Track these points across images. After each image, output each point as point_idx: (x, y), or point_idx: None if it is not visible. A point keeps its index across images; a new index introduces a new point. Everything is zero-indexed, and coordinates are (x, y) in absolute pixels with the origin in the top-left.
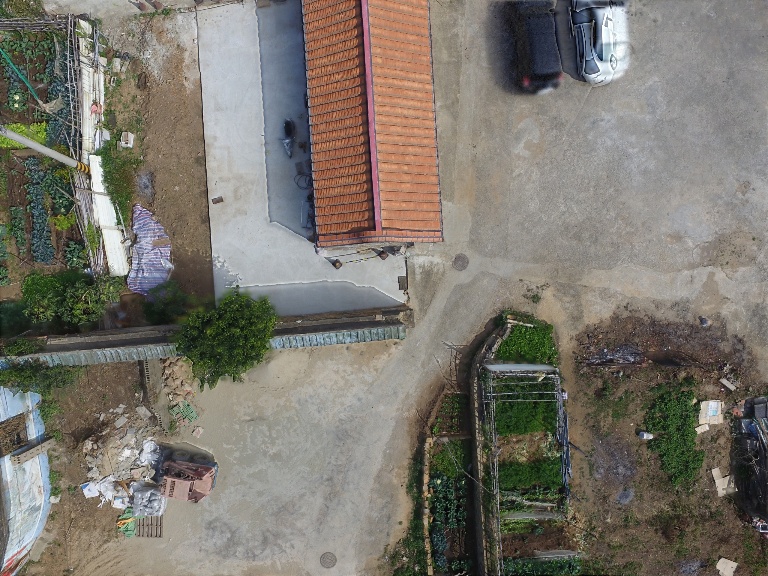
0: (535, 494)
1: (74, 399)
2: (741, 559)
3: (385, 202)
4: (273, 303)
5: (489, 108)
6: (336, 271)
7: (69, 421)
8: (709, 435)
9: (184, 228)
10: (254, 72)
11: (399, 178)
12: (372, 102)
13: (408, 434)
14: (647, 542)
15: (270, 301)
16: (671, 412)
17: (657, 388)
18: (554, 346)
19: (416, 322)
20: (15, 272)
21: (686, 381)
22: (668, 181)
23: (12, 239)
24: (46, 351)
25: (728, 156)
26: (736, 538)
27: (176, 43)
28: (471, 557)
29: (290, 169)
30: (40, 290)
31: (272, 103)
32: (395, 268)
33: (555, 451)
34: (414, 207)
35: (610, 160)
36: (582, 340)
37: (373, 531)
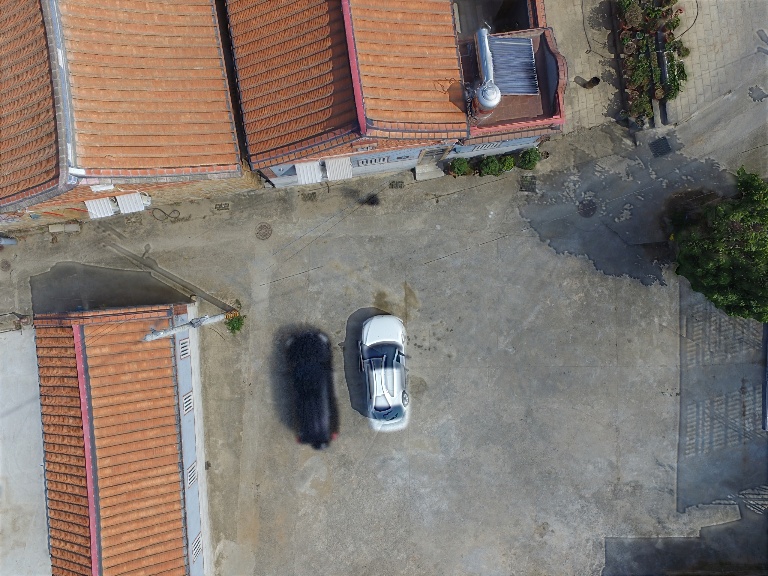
0: None
1: None
2: None
3: None
4: None
5: (273, 446)
6: None
7: None
8: None
9: None
10: (33, 401)
11: None
12: (95, 523)
13: None
14: None
15: None
16: None
17: None
18: None
19: None
20: None
21: None
22: (462, 522)
23: None
24: None
25: (526, 496)
26: None
27: None
28: None
29: None
30: None
31: None
32: None
33: None
34: None
35: (401, 499)
36: None
37: None
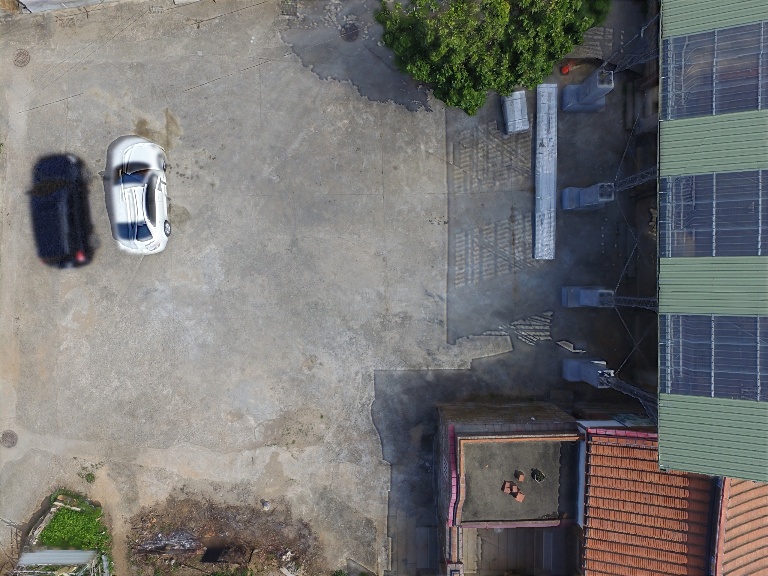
0: None
1: None
2: None
3: None
4: None
5: (33, 277)
6: None
7: None
8: None
9: None
10: None
11: None
12: None
13: None
14: None
15: None
16: None
17: None
18: (105, 530)
19: None
20: None
21: None
22: (228, 355)
23: None
24: None
25: (293, 328)
26: None
27: None
28: None
29: None
30: None
31: None
32: None
33: None
34: None
35: (166, 332)
36: (136, 524)
37: None
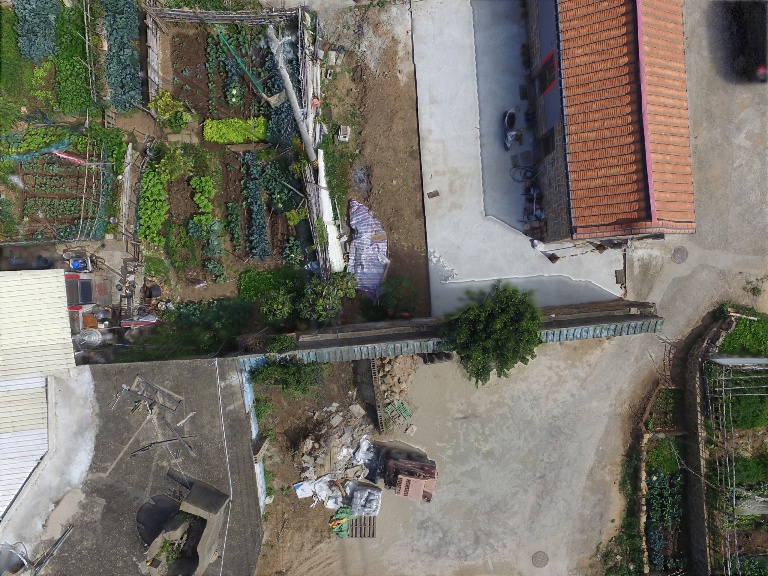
0: (760, 490)
1: (287, 398)
2: None
3: (655, 193)
4: None
5: (710, 98)
6: (552, 265)
7: (282, 420)
8: None
9: (401, 223)
10: (469, 64)
11: (664, 168)
12: (645, 91)
13: (621, 430)
14: None
15: (486, 296)
16: None
17: None
18: None
19: None
20: (230, 269)
21: None
22: None
23: (226, 236)
24: (302, 348)
25: None
26: None
27: (391, 35)
28: (685, 555)
29: (505, 162)
30: (257, 287)
31: (487, 95)
32: (612, 262)
33: None
34: (675, 198)
35: None
36: None
37: (585, 529)
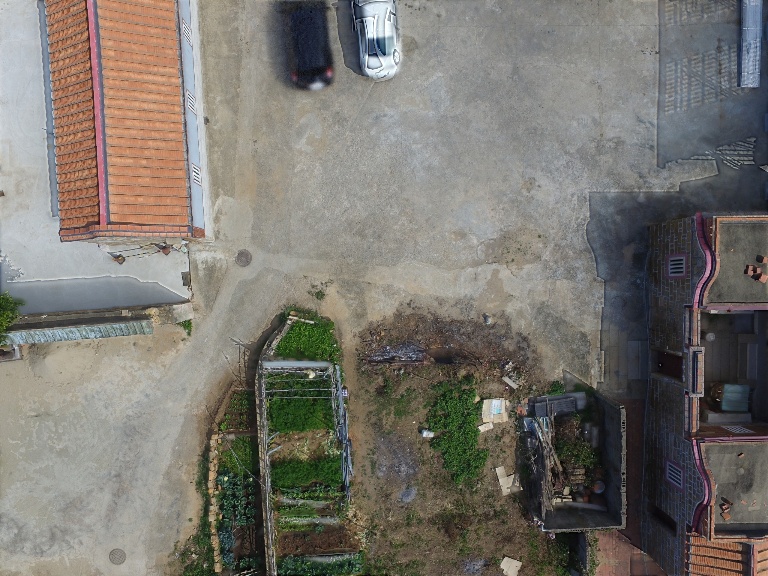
0: (316, 492)
1: None
2: (526, 558)
3: (116, 196)
4: (56, 298)
5: (270, 103)
6: (119, 266)
7: None
8: (493, 433)
9: None
10: (36, 65)
11: (135, 172)
12: (98, 95)
13: (197, 431)
14: (430, 540)
15: (53, 296)
16: (452, 410)
17: (438, 386)
18: (336, 343)
19: (203, 318)
20: None
21: (466, 379)
22: (452, 177)
23: None
24: None
25: (513, 152)
26: (521, 537)
27: None
28: (261, 554)
29: None
30: None
31: None
32: (178, 264)
33: (335, 448)
34: (154, 201)
35: (394, 156)
36: (365, 337)
37: (163, 528)
